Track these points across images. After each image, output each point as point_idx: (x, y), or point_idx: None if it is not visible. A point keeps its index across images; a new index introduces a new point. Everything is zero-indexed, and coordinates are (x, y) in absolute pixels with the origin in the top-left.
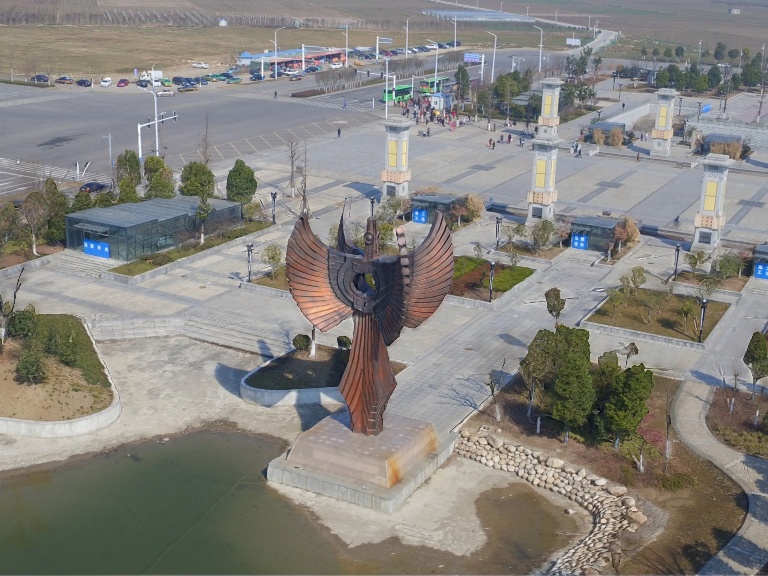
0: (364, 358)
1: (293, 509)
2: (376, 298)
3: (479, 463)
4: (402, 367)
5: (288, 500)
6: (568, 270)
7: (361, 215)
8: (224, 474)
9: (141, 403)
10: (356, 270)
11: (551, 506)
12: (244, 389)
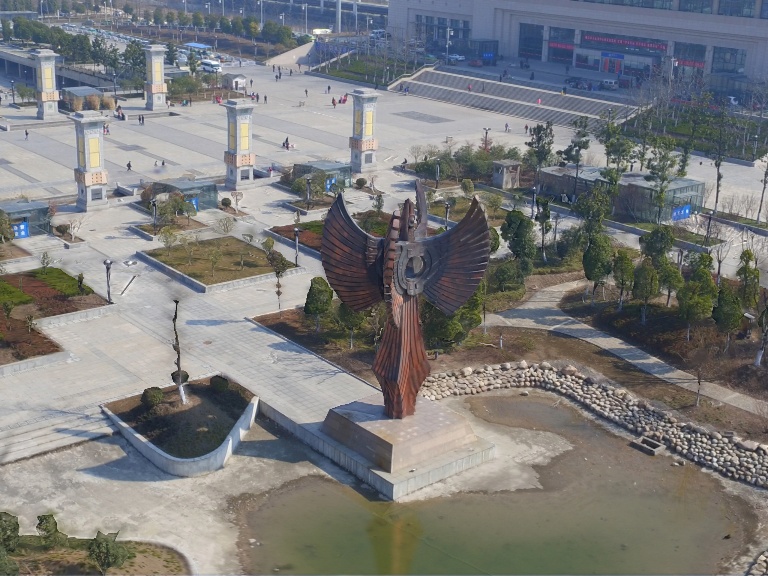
0: (411, 341)
1: (460, 500)
2: (428, 276)
3: None
4: None
5: (441, 499)
6: (62, 258)
7: None
8: (359, 522)
9: None
10: (409, 256)
11: (511, 398)
12: (193, 464)
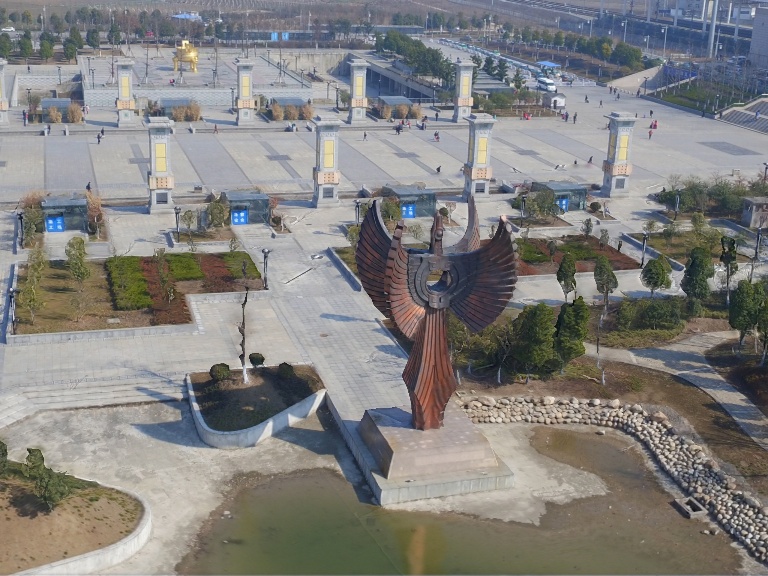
0: (436, 354)
1: (446, 518)
2: (454, 291)
3: (490, 424)
4: (308, 368)
5: (428, 513)
6: (262, 246)
7: None
8: (335, 518)
9: (137, 491)
10: (432, 269)
11: (583, 434)
12: (221, 437)
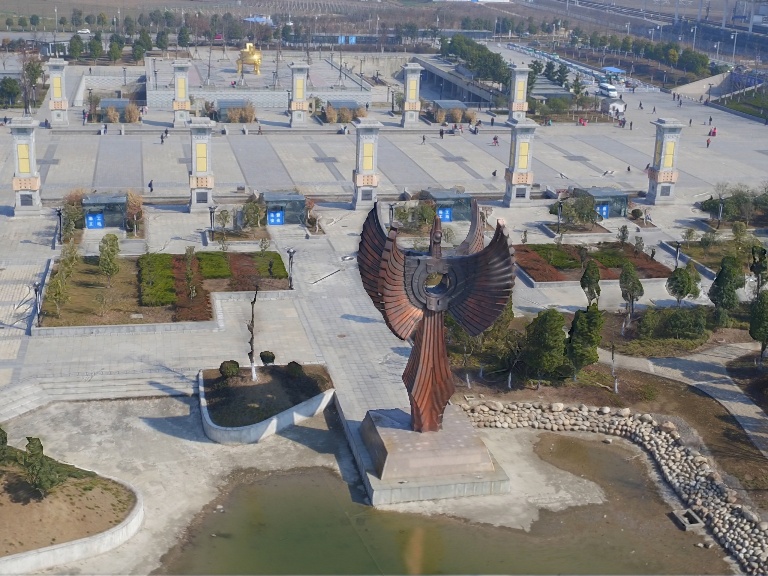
0: (434, 356)
1: (436, 521)
2: (452, 294)
3: (496, 428)
4: (321, 368)
5: (419, 515)
6: (295, 246)
7: (16, 232)
8: (325, 517)
9: (135, 482)
10: (430, 271)
11: (590, 442)
12: (224, 432)
